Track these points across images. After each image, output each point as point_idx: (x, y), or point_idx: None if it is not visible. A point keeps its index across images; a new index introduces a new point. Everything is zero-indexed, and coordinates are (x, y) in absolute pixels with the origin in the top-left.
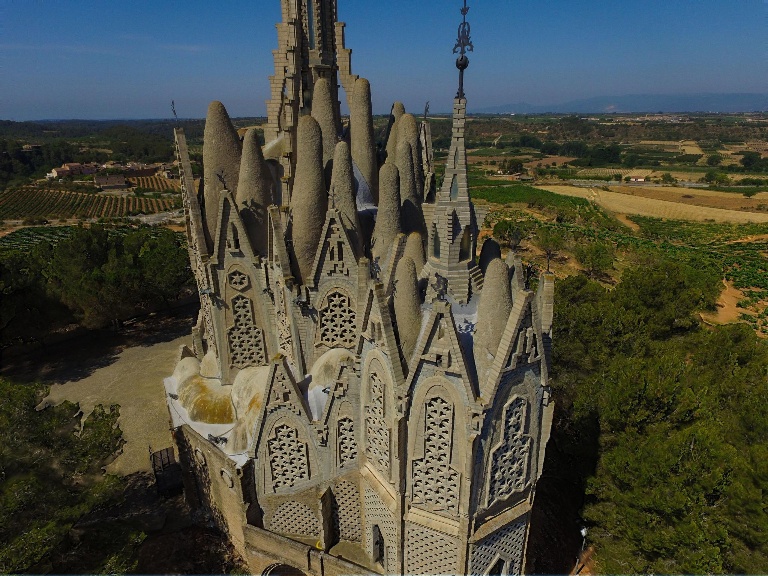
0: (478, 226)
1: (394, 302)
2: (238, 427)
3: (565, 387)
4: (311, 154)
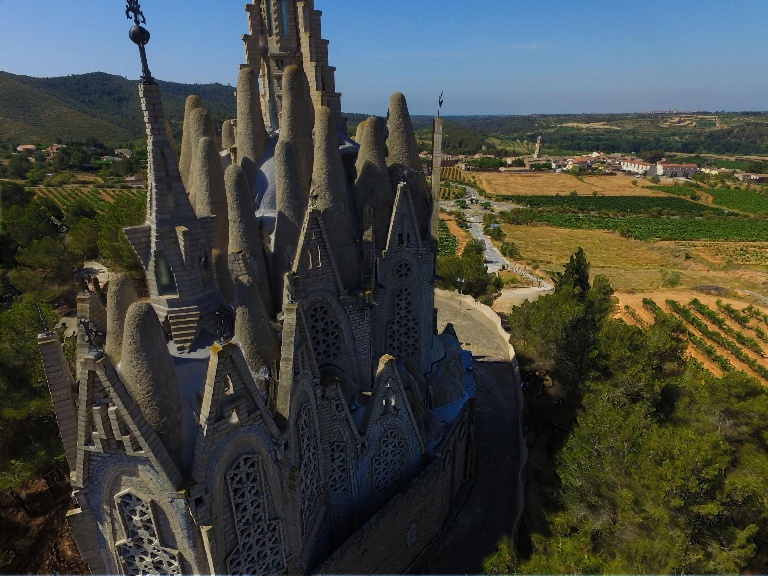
0: (183, 255)
1: None
2: None
3: (604, 536)
4: (196, 150)
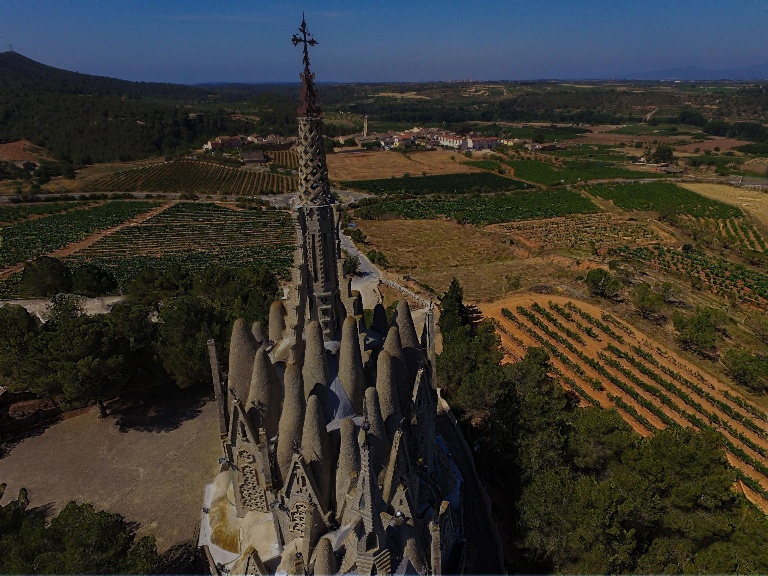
0: (384, 527)
1: (314, 569)
2: (234, 571)
3: (554, 549)
4: (293, 396)
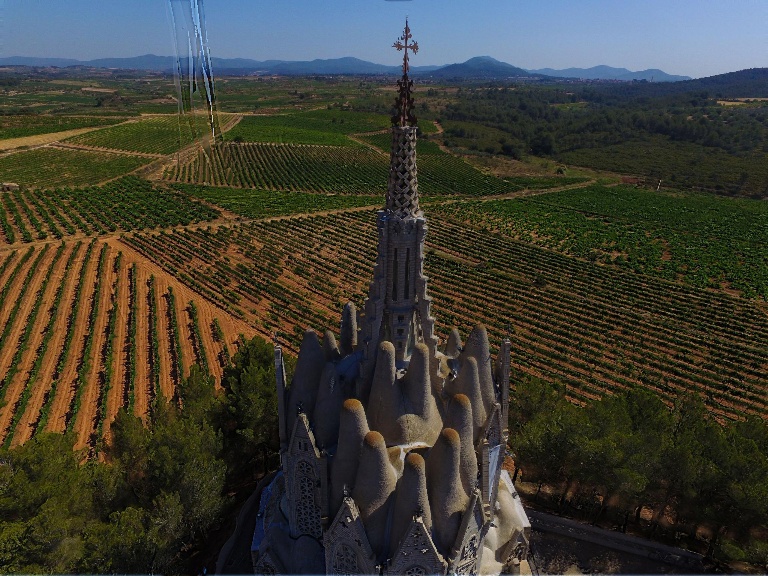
0: None
1: None
2: None
3: None
4: None
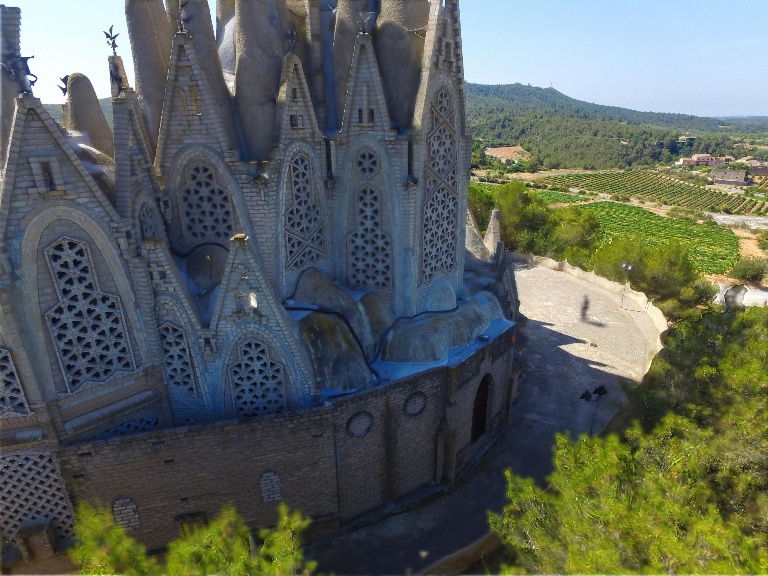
0: None
1: None
2: None
3: None
4: None
